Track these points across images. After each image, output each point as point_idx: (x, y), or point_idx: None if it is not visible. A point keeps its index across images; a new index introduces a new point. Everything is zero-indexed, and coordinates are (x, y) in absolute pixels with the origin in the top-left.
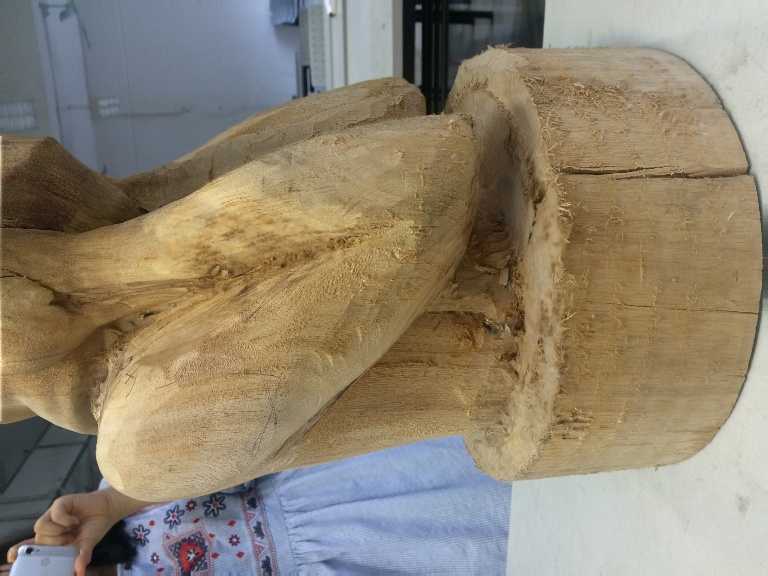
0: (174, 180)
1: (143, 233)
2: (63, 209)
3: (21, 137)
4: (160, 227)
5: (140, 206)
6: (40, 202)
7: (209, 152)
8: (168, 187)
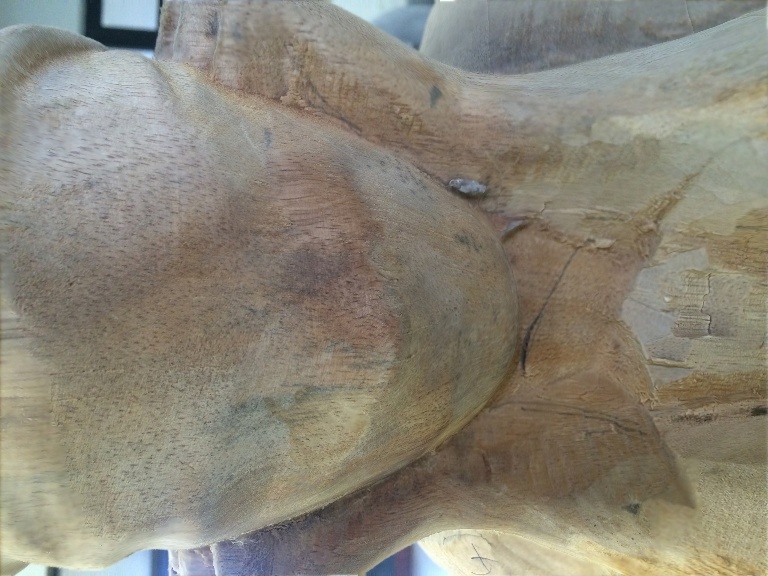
0: (598, 164)
1: (565, 547)
2: (420, 453)
3: (334, 352)
4: (598, 559)
5: (507, 204)
6: (386, 470)
7: (715, 138)
8: (578, 172)
